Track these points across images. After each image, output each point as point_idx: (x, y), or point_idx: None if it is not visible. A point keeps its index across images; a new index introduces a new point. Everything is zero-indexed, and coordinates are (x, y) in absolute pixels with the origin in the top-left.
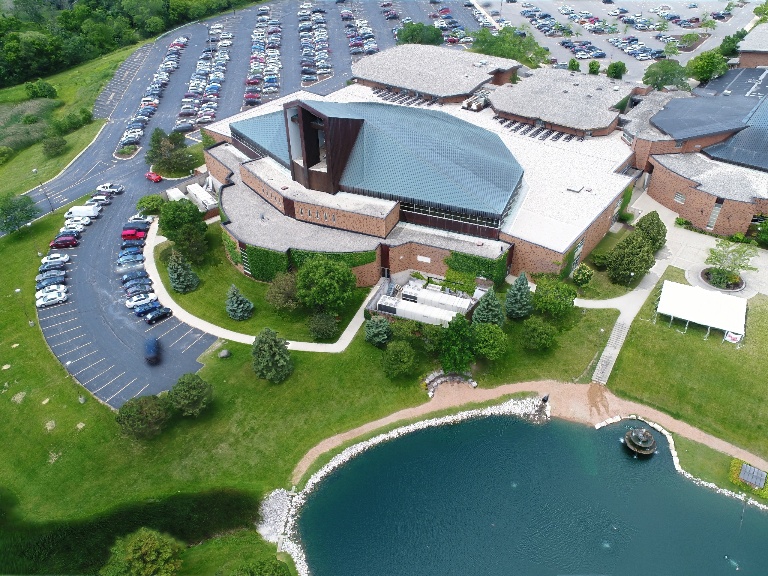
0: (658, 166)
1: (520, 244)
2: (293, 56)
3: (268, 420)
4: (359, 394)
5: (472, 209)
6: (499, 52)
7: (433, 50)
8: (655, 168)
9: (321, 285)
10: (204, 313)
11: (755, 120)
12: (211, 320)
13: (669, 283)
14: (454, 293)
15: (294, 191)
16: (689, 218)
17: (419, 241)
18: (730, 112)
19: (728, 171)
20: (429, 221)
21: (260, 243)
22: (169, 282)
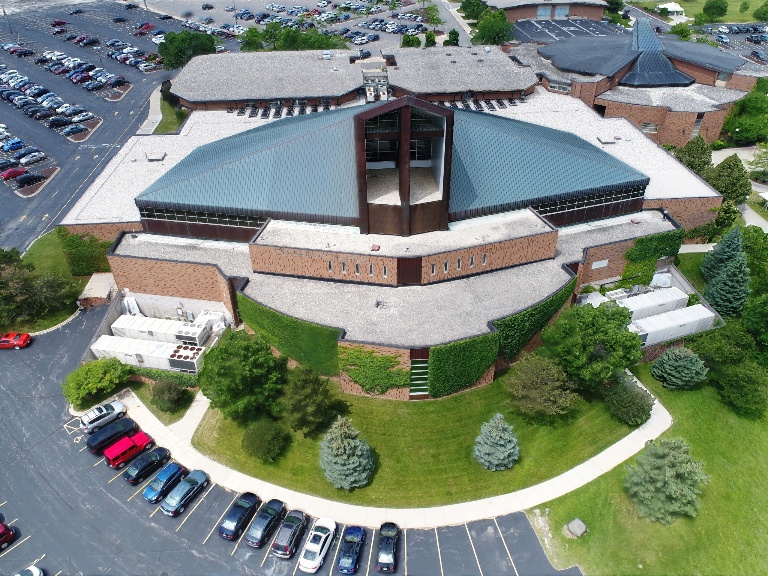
0: (613, 104)
1: (669, 205)
2: (3, 110)
3: (753, 573)
4: (752, 458)
5: (619, 183)
6: (315, 44)
7: (244, 55)
8: (609, 108)
9: (624, 343)
10: (446, 492)
11: (643, 46)
12: (473, 494)
13: (767, 194)
14: (628, 291)
15: (395, 246)
16: (670, 142)
17: (586, 244)
18: (609, 46)
19: (662, 93)
20: (565, 219)
21: (437, 337)
22: (311, 483)
